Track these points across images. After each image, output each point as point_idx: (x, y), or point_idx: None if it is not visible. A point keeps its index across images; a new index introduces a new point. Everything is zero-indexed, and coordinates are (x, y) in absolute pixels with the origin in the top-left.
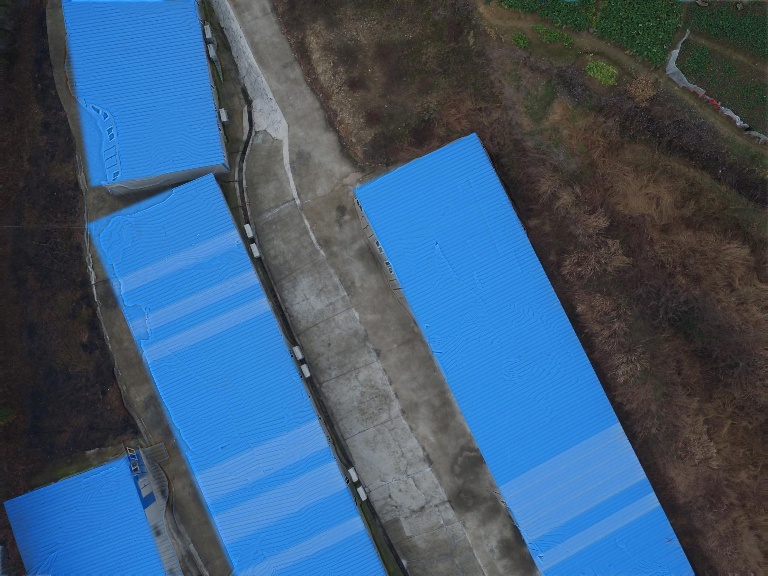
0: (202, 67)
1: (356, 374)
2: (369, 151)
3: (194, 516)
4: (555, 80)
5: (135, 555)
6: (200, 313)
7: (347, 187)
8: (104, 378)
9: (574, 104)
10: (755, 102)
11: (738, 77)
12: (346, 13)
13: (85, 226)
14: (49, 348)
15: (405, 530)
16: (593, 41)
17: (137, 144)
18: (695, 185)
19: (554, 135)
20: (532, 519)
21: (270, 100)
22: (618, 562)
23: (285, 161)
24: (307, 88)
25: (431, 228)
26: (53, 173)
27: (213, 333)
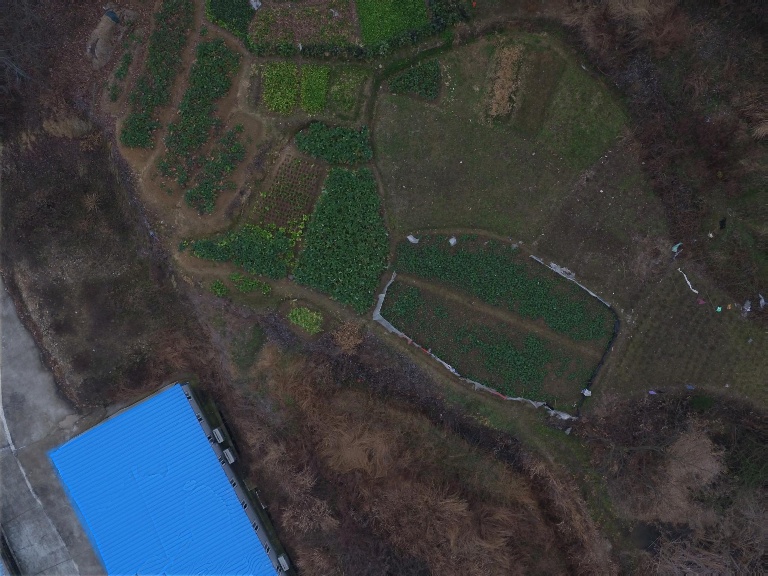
0: None
1: None
2: (83, 394)
3: None
4: (263, 324)
5: None
6: None
7: (63, 431)
8: None
9: (285, 348)
10: (469, 346)
11: (451, 320)
12: (50, 252)
13: None
14: None
15: None
16: (294, 287)
17: None
18: (411, 434)
19: (261, 385)
20: None
21: None
22: None
23: None
24: (21, 325)
25: (90, 527)
26: None
27: None
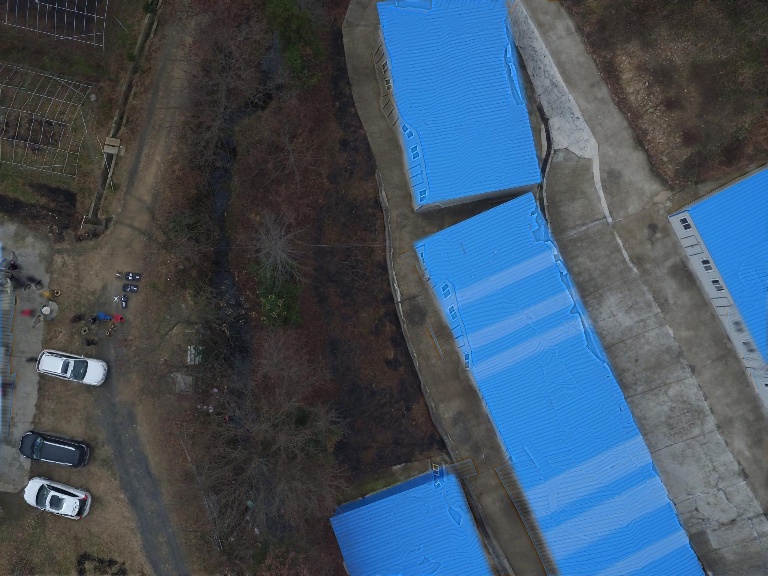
0: (503, 86)
1: (666, 390)
2: (681, 170)
3: (506, 531)
4: None
5: (450, 571)
6: (522, 331)
7: (658, 205)
8: (409, 395)
9: None
10: None
11: None
12: (661, 34)
13: (386, 244)
14: (352, 366)
15: (712, 542)
16: None
17: (443, 163)
18: None
19: None
20: None
21: (576, 119)
22: None
23: (596, 180)
24: (615, 107)
25: None
26: (351, 191)
27: (529, 350)
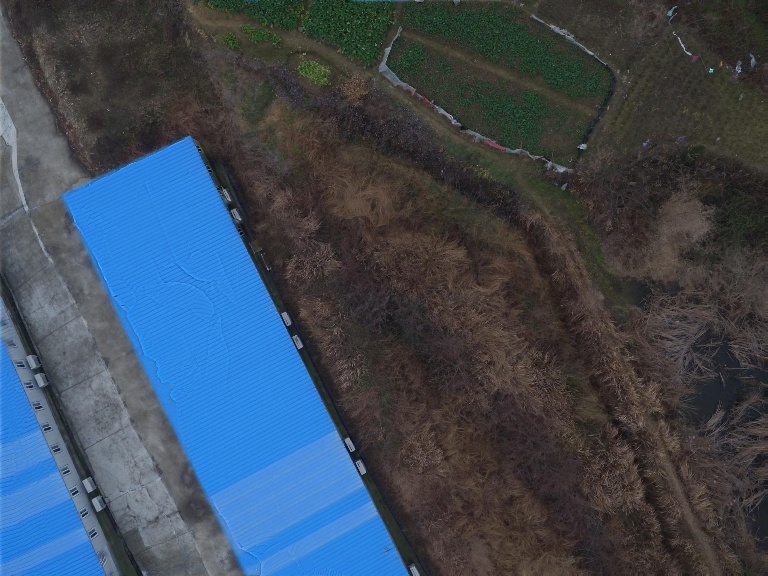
0: None
1: (89, 383)
2: (96, 156)
3: None
4: (272, 81)
5: None
6: None
7: None
8: None
9: (293, 105)
10: (470, 100)
11: (453, 74)
12: (68, 16)
13: None
14: None
15: (143, 541)
16: (304, 40)
17: None
18: (413, 186)
19: (269, 137)
20: (243, 529)
21: (2, 105)
22: (290, 574)
23: (14, 167)
24: (37, 93)
25: None
26: None
27: None
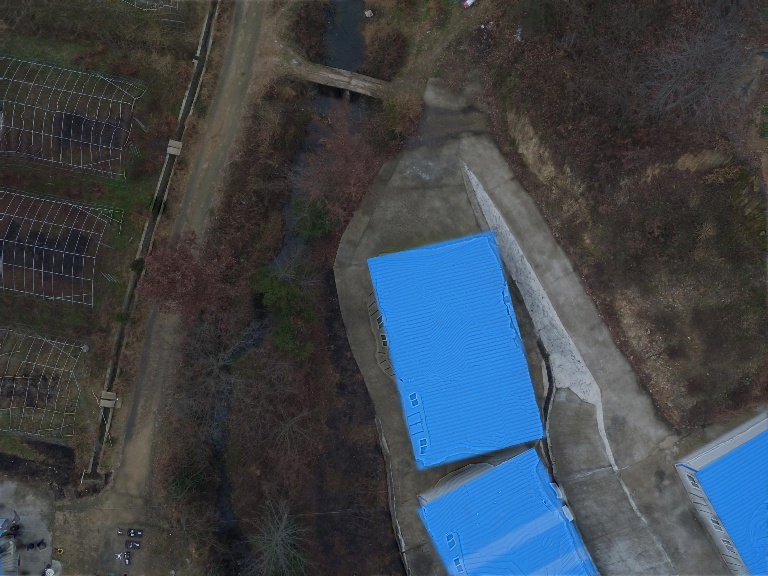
0: None
1: None
2: (687, 416)
3: None
4: None
5: None
6: None
7: (664, 451)
8: None
9: None
10: None
11: None
12: (661, 280)
13: (388, 490)
14: None
15: None
16: None
17: (443, 411)
18: None
19: None
20: None
21: (577, 362)
22: None
23: (600, 427)
24: (616, 350)
25: None
26: (351, 436)
27: None
